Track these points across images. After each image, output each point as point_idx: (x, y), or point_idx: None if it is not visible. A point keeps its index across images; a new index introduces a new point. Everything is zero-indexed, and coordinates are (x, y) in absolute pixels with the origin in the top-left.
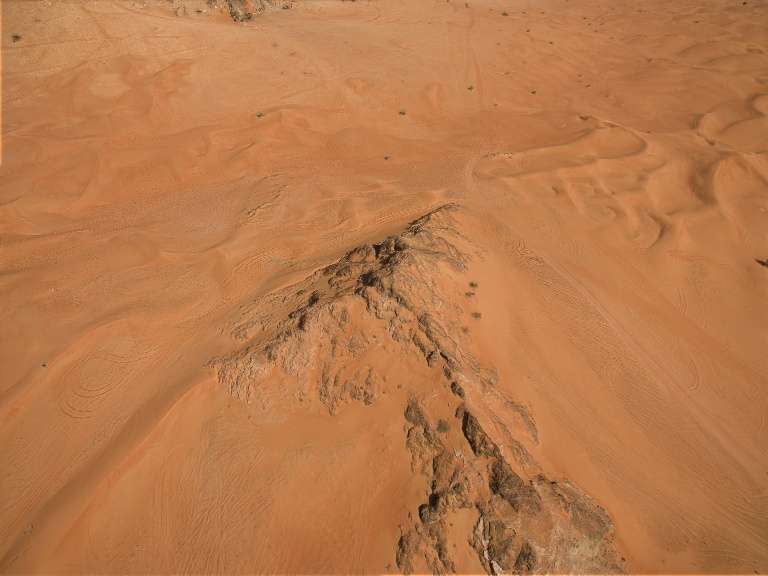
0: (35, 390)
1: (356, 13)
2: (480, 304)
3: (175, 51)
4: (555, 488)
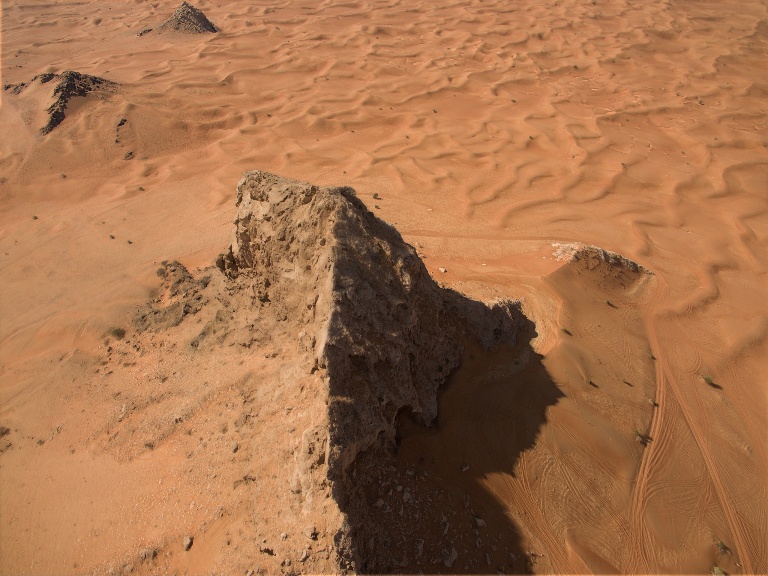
0: None
1: (5, 366)
2: None
3: (225, 213)
4: None
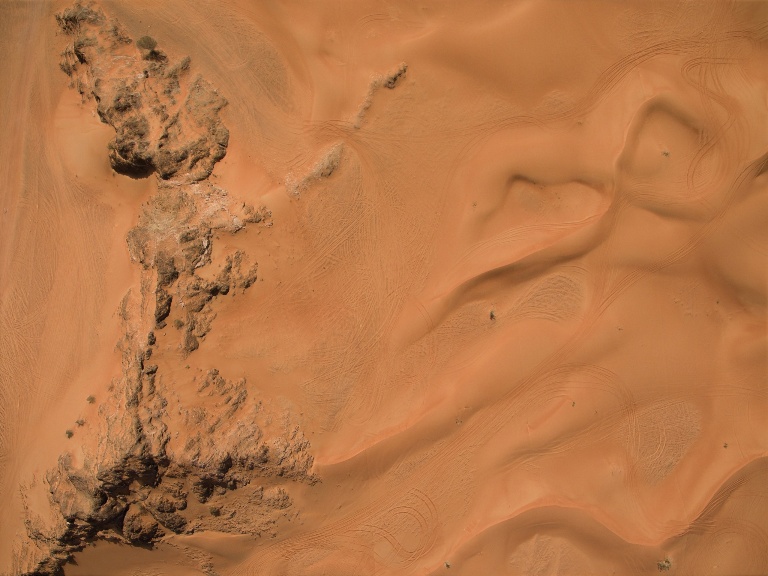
0: (456, 543)
1: None
2: (81, 412)
3: None
4: (143, 259)
